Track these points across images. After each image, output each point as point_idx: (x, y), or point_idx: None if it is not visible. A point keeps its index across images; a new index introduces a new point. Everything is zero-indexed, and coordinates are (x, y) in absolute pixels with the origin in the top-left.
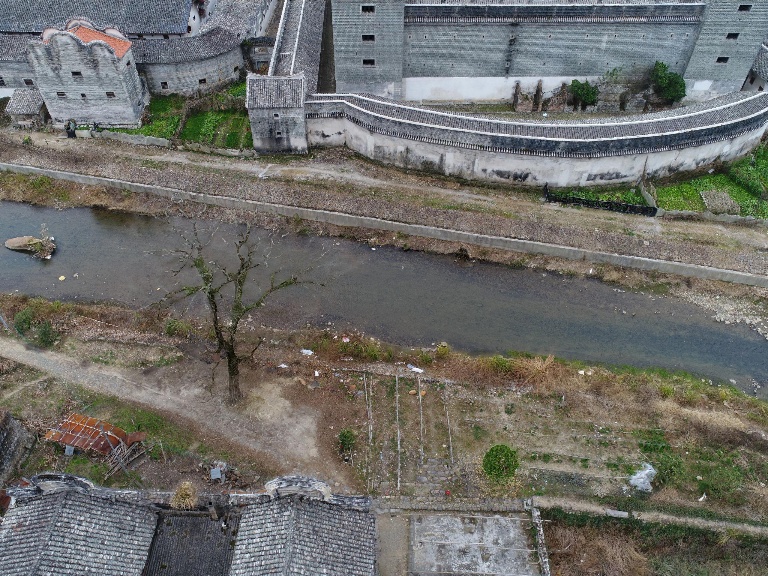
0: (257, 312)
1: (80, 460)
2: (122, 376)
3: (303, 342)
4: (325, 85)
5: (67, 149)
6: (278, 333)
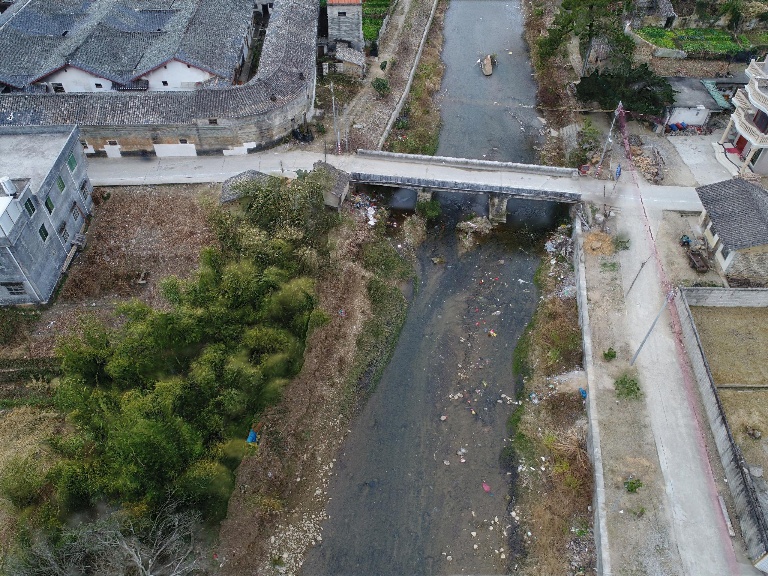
0: (512, 7)
1: (623, 7)
2: None
3: None
4: None
5: (394, 54)
6: (525, 0)
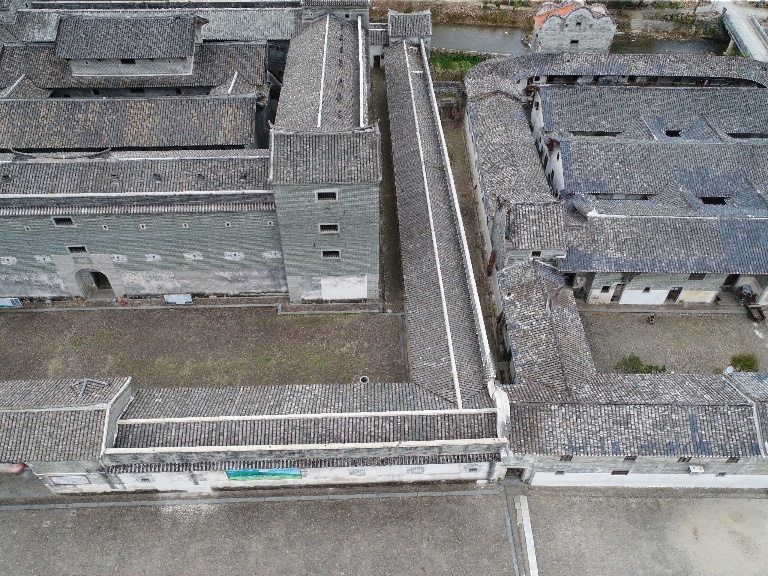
0: None
1: None
2: (447, 0)
3: (377, 8)
4: (383, 110)
5: None
6: None
